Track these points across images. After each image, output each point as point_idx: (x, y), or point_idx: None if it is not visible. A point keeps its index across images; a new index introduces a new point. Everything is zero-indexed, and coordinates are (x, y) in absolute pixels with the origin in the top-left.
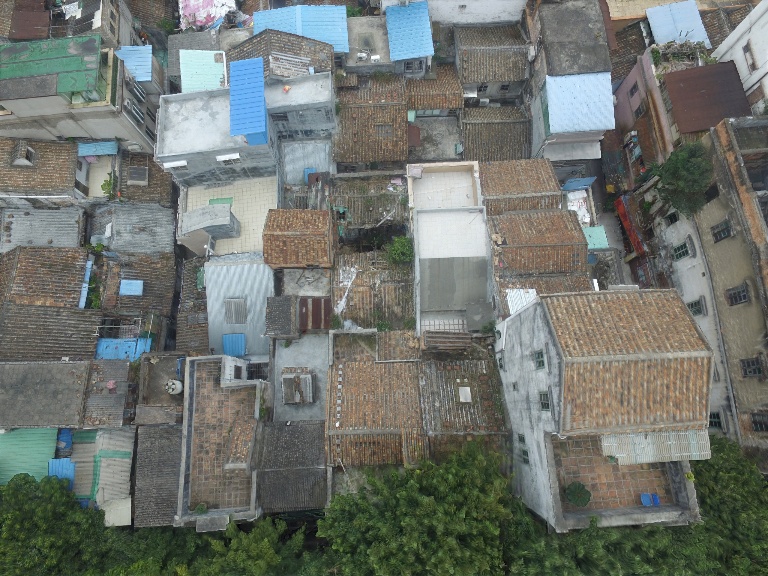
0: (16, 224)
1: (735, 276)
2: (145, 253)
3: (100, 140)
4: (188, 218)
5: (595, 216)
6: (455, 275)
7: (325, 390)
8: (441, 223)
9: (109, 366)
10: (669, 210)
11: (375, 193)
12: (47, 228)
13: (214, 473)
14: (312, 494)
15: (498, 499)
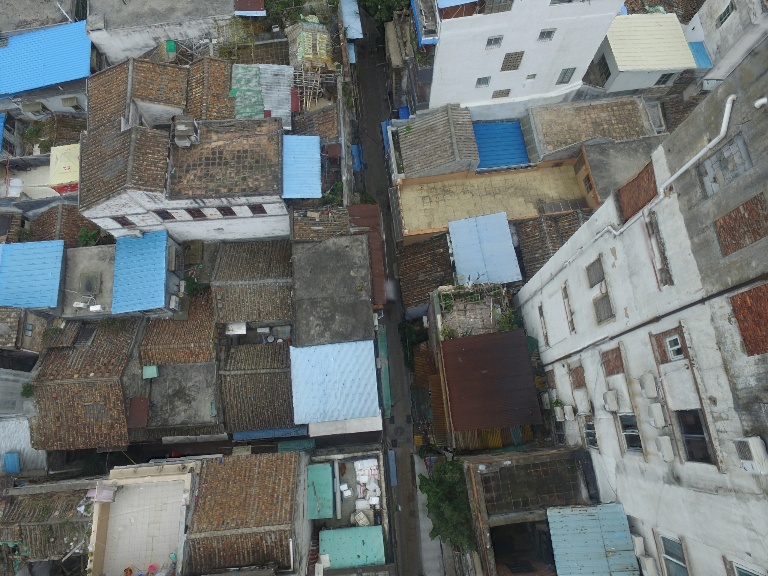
0: None
1: None
2: None
3: None
4: None
5: (384, 496)
6: None
7: None
8: None
9: None
10: None
11: (57, 518)
12: None
13: None
14: None
15: None
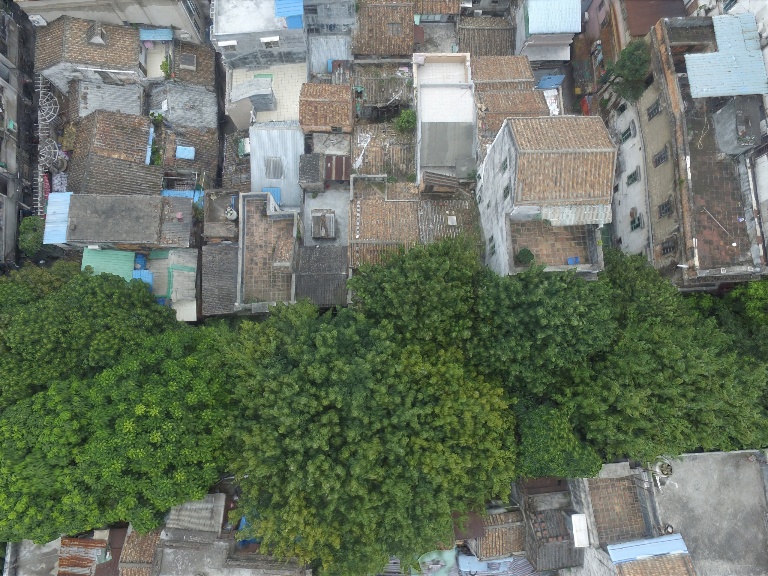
0: (90, 95)
1: (660, 143)
2: (195, 127)
3: (158, 27)
4: (237, 90)
5: (563, 110)
6: (448, 137)
7: (343, 231)
8: (439, 96)
9: (177, 202)
10: (620, 102)
11: (386, 77)
12: (115, 100)
13: (262, 278)
14: (336, 294)
15: None
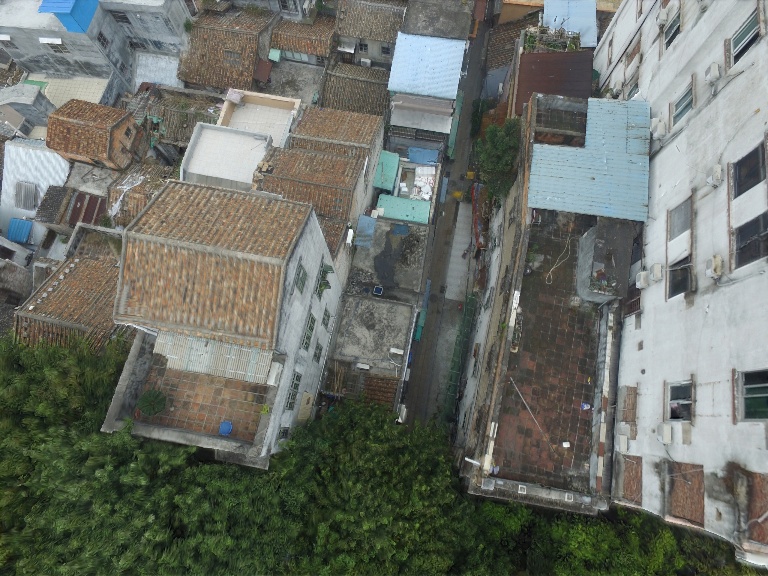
0: None
1: (508, 263)
2: None
3: None
4: (2, 93)
5: (435, 194)
6: None
7: None
8: (223, 143)
9: None
10: None
11: (193, 111)
12: None
13: None
14: None
15: (89, 394)
